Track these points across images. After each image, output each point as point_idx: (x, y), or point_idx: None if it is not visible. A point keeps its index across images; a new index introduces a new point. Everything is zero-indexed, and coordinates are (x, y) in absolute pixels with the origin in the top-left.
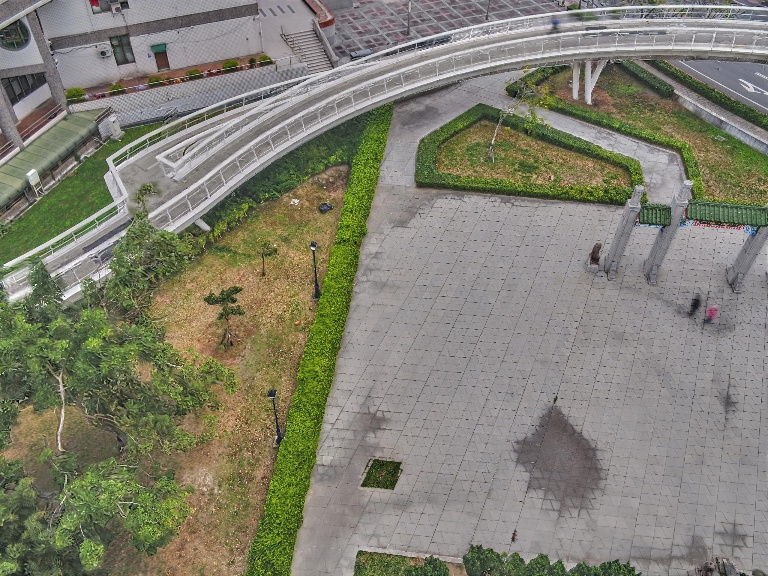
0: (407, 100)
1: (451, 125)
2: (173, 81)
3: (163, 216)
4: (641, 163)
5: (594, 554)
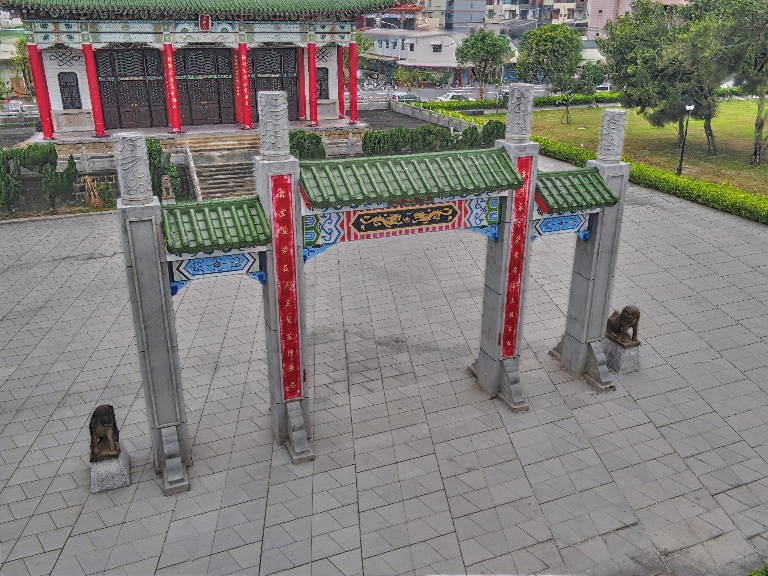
0: None
1: None
2: None
3: None
4: None
5: None
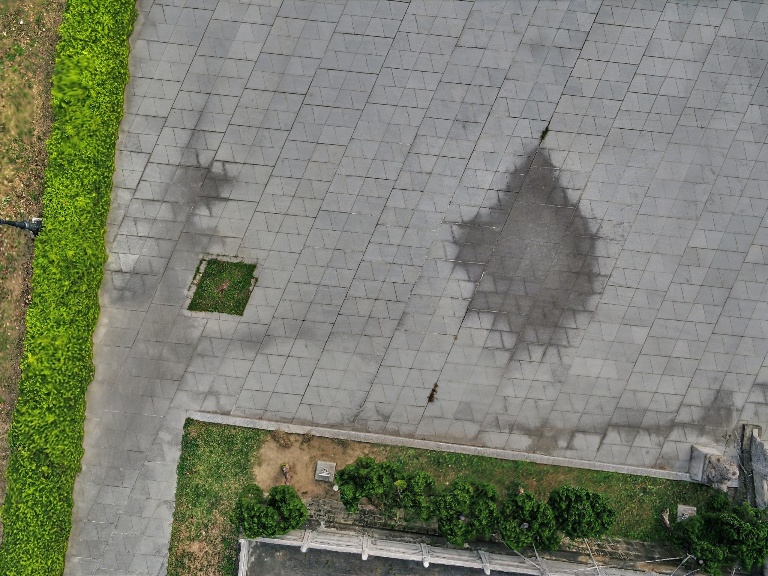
0: None
1: None
2: None
3: None
4: None
5: (554, 421)
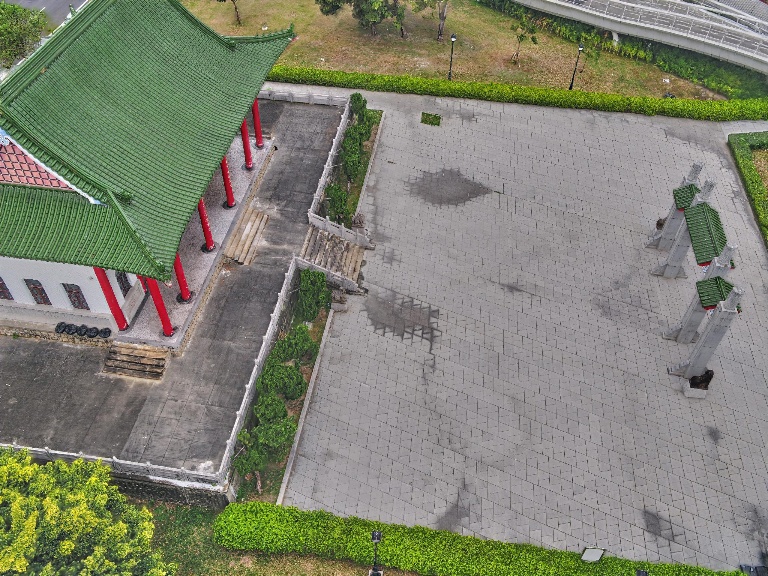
0: None
1: None
2: (767, 1)
3: (595, 6)
4: None
5: (380, 192)
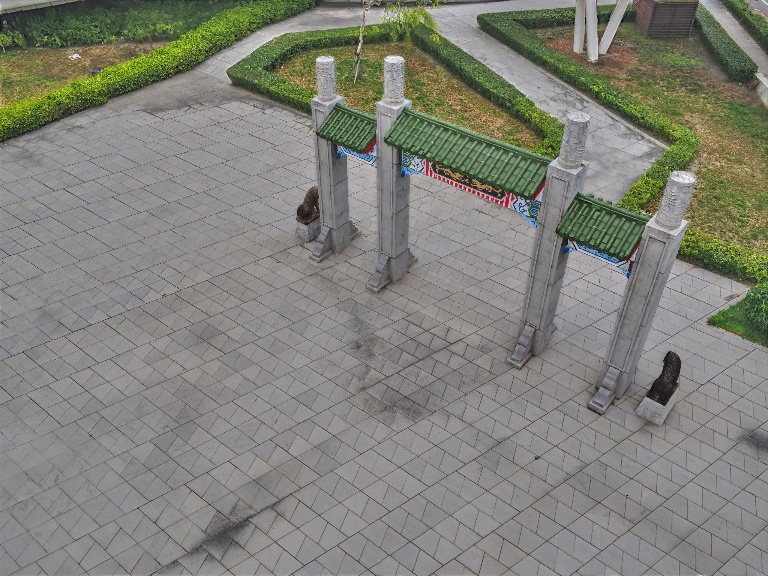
0: (343, 7)
1: (344, 30)
2: None
3: None
4: (589, 144)
5: None
